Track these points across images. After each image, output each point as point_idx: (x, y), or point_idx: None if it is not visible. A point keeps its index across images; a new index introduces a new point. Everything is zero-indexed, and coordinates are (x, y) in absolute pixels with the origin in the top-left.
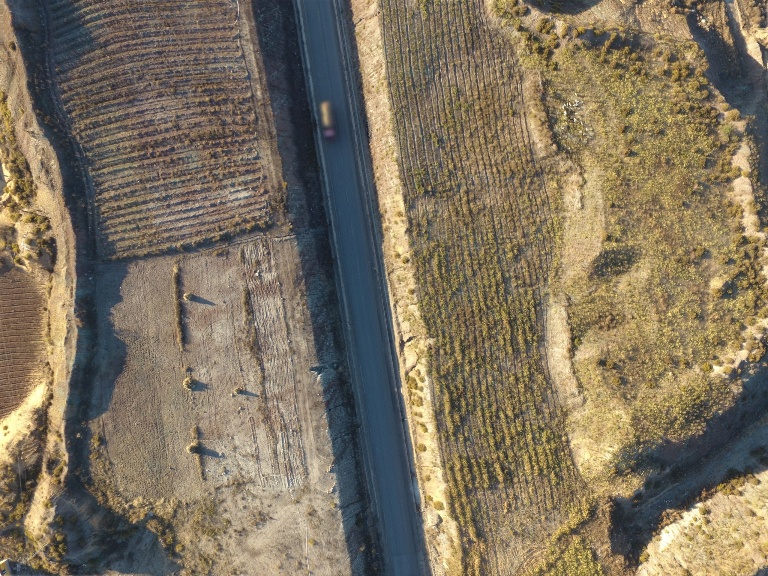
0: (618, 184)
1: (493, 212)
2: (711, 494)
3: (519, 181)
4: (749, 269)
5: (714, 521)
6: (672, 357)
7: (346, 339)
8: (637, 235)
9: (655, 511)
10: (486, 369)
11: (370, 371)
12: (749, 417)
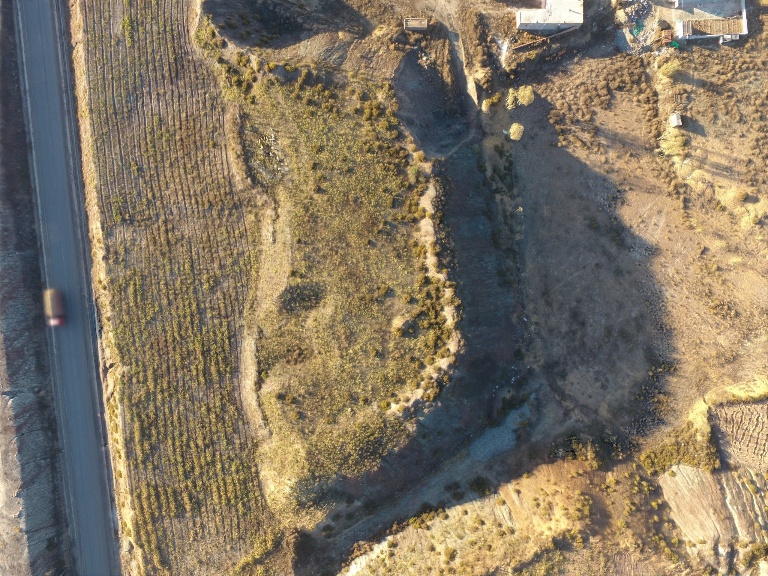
0: (305, 220)
1: (191, 243)
2: (402, 527)
3: (217, 213)
4: (430, 309)
5: (397, 554)
6: (351, 393)
7: (52, 363)
8: (322, 272)
9: (348, 542)
10: (178, 398)
11: (74, 396)
12: (445, 452)
